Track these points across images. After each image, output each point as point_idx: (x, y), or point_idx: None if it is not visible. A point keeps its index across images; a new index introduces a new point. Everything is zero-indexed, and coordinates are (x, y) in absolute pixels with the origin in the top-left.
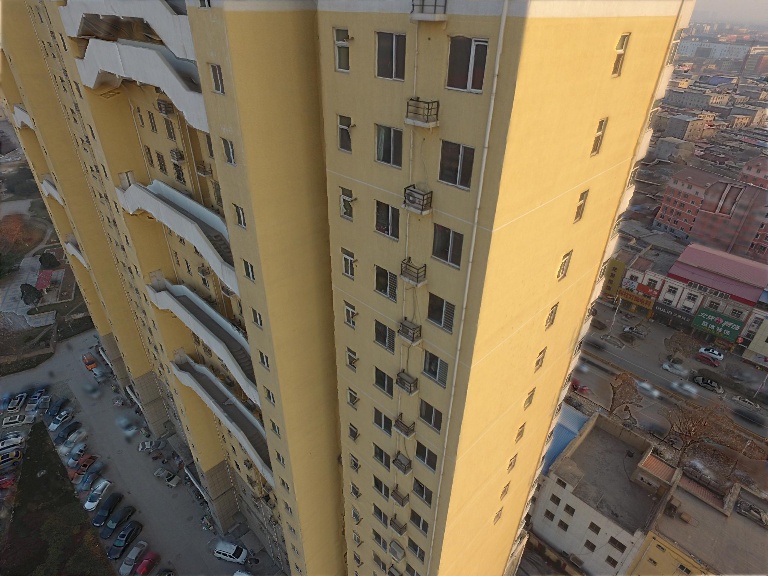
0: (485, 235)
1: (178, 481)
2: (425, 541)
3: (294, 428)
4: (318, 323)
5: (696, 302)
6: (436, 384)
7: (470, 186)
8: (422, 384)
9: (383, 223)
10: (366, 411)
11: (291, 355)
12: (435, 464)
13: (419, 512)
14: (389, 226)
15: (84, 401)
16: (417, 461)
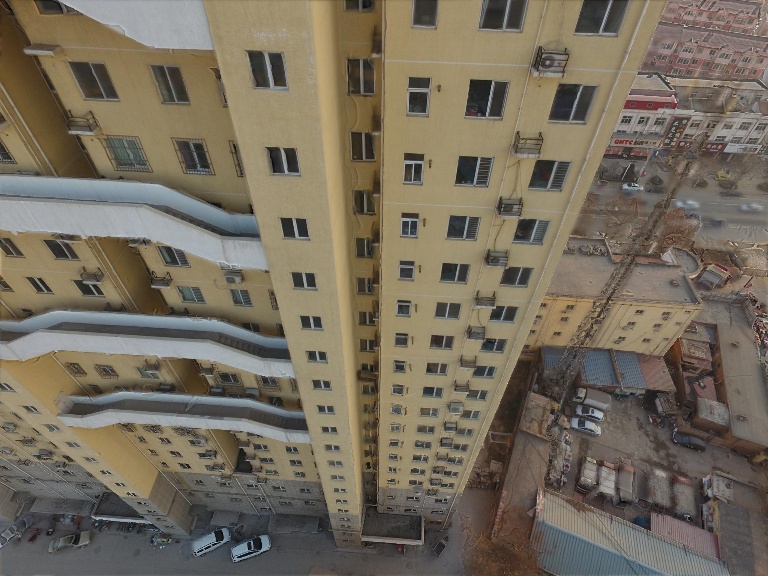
0: (626, 79)
1: (88, 535)
2: (491, 382)
3: (347, 371)
4: (345, 255)
5: None
6: (531, 245)
7: (618, 30)
8: (513, 253)
9: (473, 105)
10: (427, 311)
11: (342, 301)
12: (513, 315)
13: (488, 363)
14: (488, 106)
15: None
16: (493, 323)
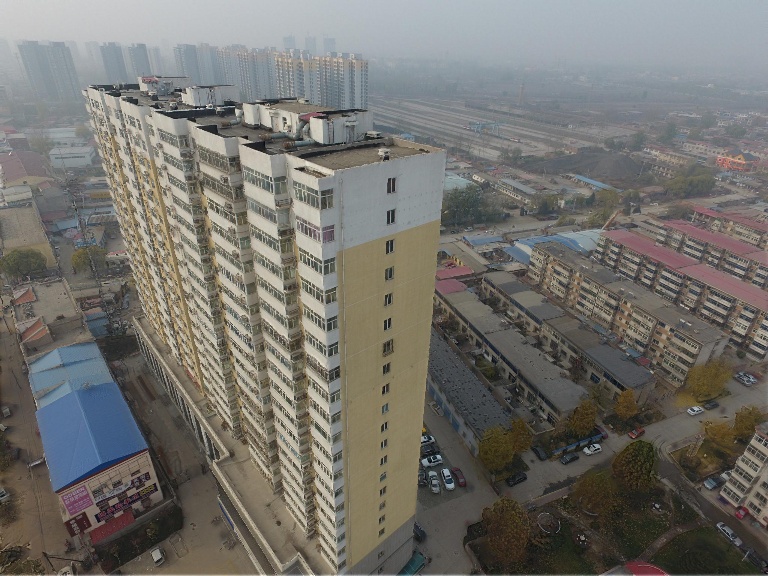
0: None
1: None
2: None
3: None
4: None
5: None
6: None
7: None
8: None
9: None
10: None
11: None
12: None
13: None
14: None
15: None
16: None
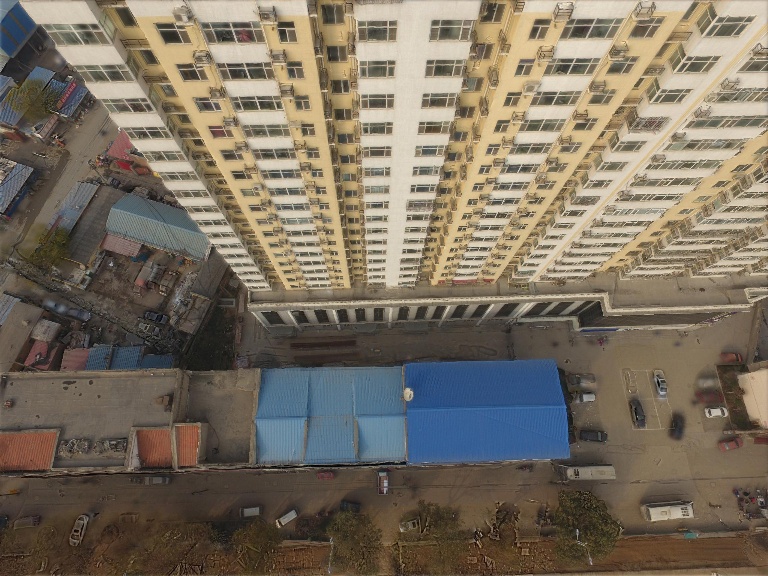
0: None
1: None
2: None
3: None
4: None
5: None
6: None
7: None
8: None
9: None
10: None
11: None
12: None
13: None
14: None
15: None
16: None
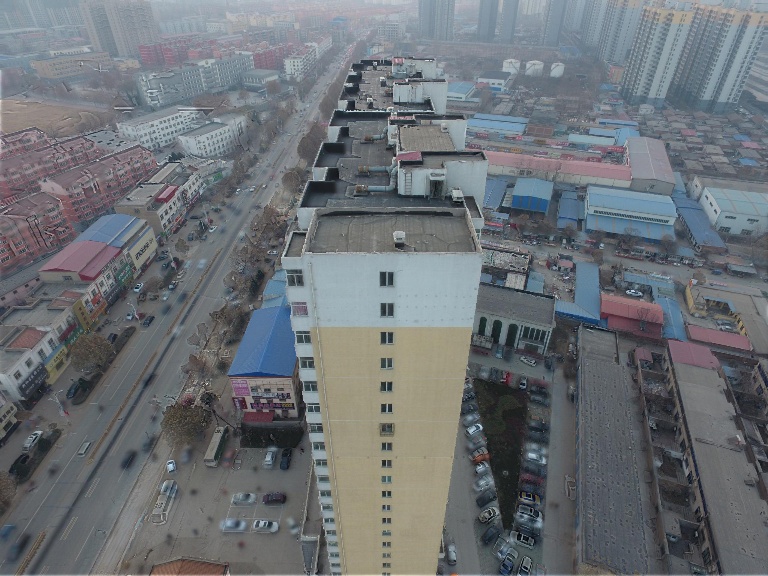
0: None
1: None
2: None
3: None
4: None
5: (111, 276)
6: None
7: None
8: None
9: None
10: None
11: None
12: None
13: None
14: None
15: (470, 532)
16: None
